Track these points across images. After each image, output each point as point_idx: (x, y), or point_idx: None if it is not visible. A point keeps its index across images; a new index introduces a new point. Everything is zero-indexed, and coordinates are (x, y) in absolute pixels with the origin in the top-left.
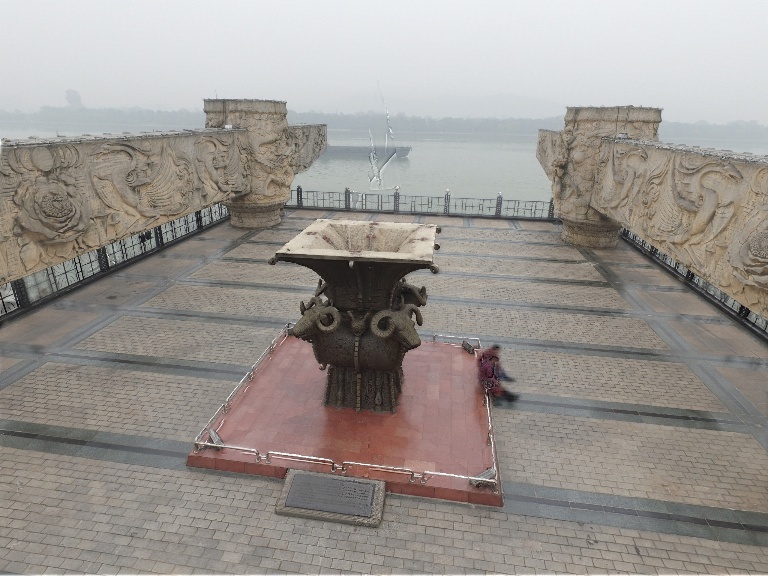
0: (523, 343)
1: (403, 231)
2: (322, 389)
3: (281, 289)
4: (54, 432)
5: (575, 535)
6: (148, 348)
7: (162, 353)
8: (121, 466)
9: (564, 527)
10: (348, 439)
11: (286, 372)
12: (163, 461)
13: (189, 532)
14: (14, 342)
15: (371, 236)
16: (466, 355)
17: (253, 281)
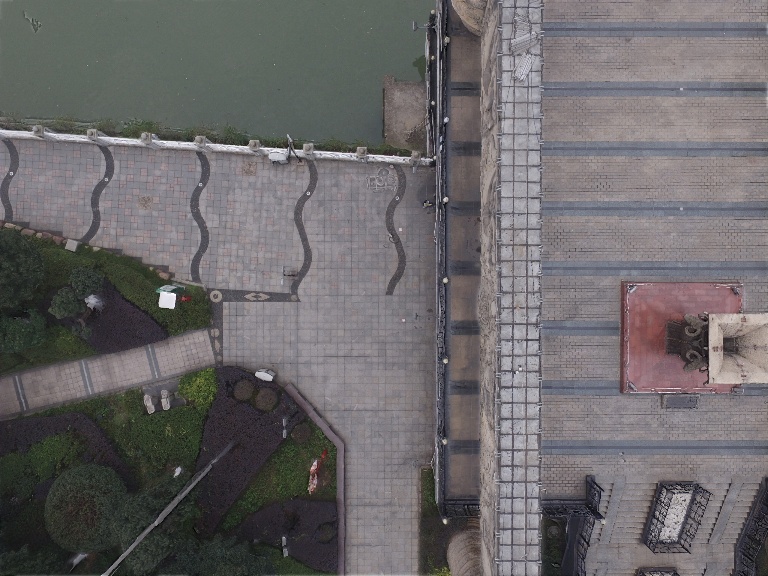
0: (765, 268)
1: (759, 325)
2: (663, 342)
3: (592, 211)
4: (556, 384)
5: (761, 401)
6: (551, 313)
7: (562, 317)
8: (596, 397)
9: (758, 398)
10: (682, 374)
11: (641, 330)
12: (610, 392)
13: (637, 420)
14: (472, 320)
15: (740, 330)
16: (733, 297)
17: (565, 199)
